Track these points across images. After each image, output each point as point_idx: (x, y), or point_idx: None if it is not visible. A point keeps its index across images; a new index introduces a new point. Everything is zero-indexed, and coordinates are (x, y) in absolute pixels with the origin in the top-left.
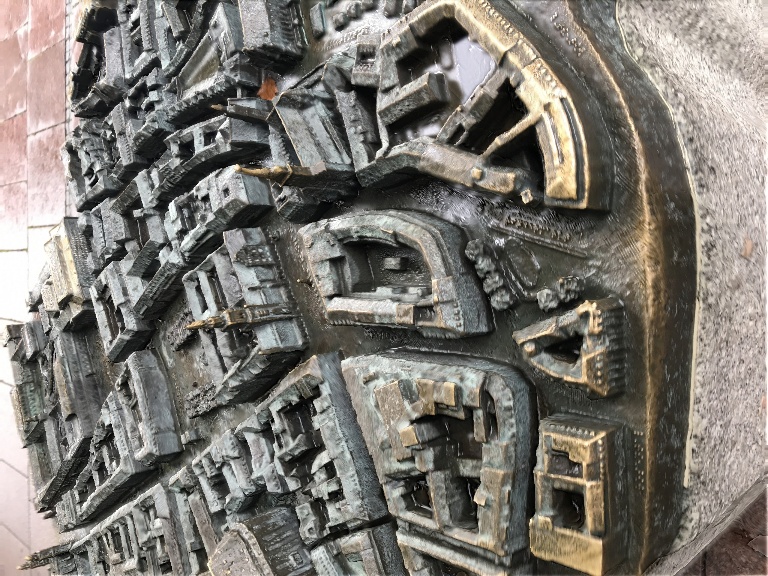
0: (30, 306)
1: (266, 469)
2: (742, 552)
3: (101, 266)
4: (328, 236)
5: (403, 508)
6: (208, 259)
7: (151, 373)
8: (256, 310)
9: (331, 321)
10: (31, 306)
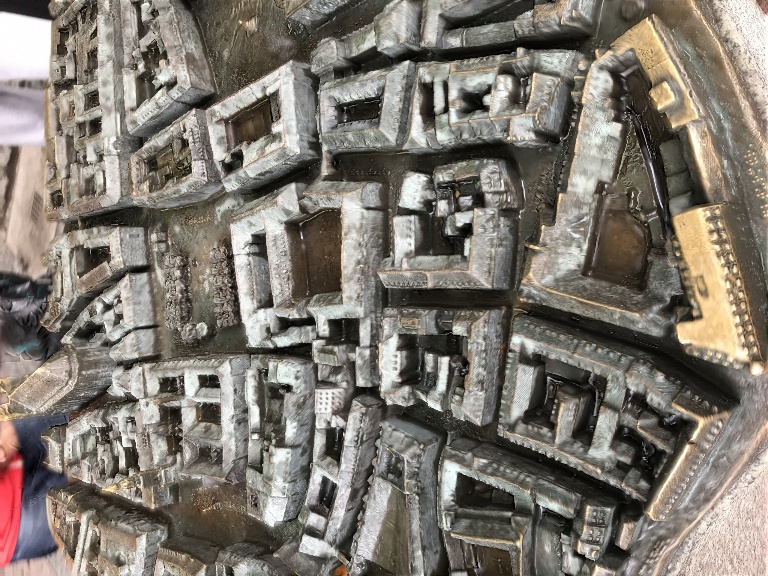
0: None
1: (118, 393)
2: None
3: (323, 76)
4: None
5: (93, 529)
6: (222, 427)
7: (199, 194)
8: None
9: None
10: None
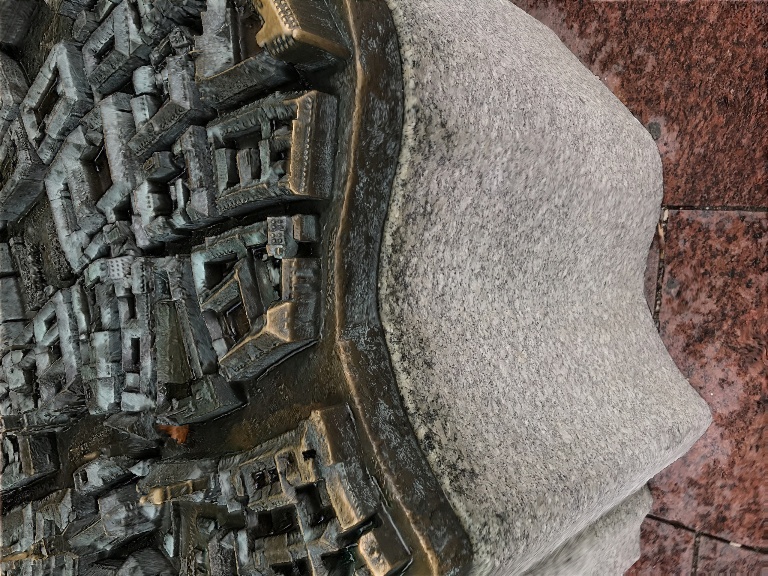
0: None
1: None
2: None
3: (85, 41)
4: None
5: None
6: (61, 348)
7: (32, 183)
8: (33, 428)
9: None
10: None
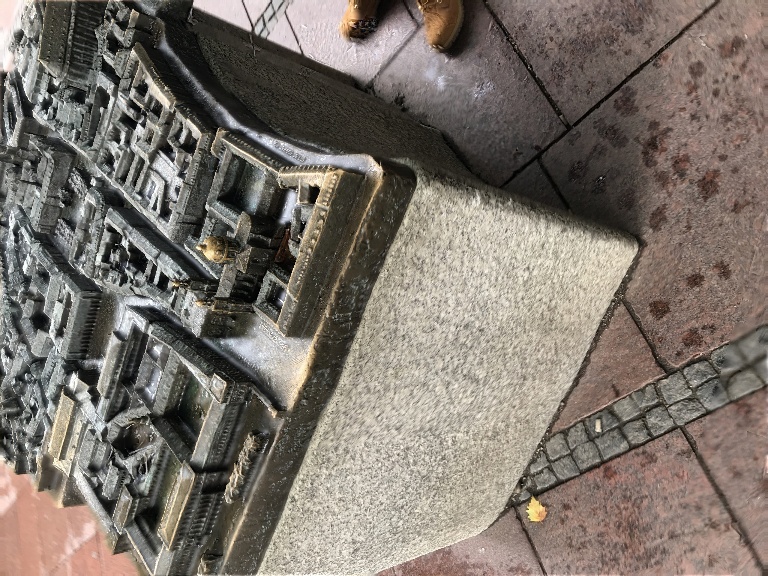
0: (111, 529)
1: None
2: (378, 47)
3: None
4: (8, 140)
5: None
6: None
7: None
8: None
9: (21, 115)
10: (111, 527)
